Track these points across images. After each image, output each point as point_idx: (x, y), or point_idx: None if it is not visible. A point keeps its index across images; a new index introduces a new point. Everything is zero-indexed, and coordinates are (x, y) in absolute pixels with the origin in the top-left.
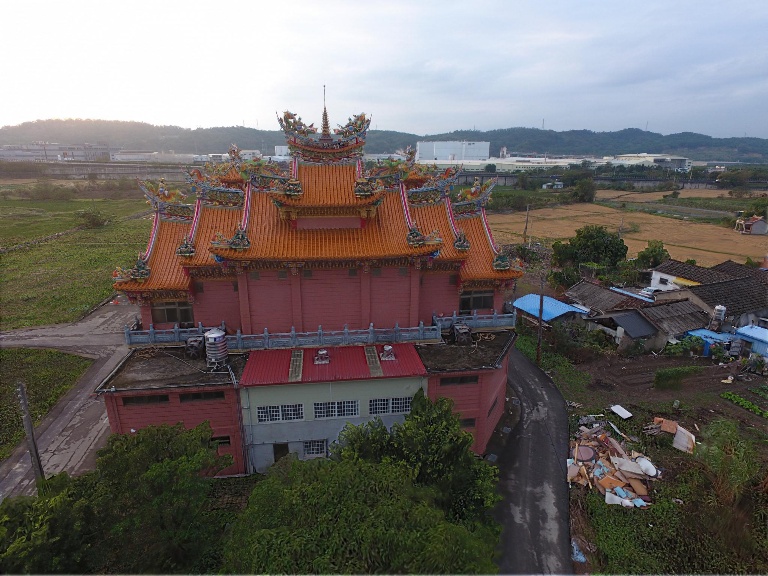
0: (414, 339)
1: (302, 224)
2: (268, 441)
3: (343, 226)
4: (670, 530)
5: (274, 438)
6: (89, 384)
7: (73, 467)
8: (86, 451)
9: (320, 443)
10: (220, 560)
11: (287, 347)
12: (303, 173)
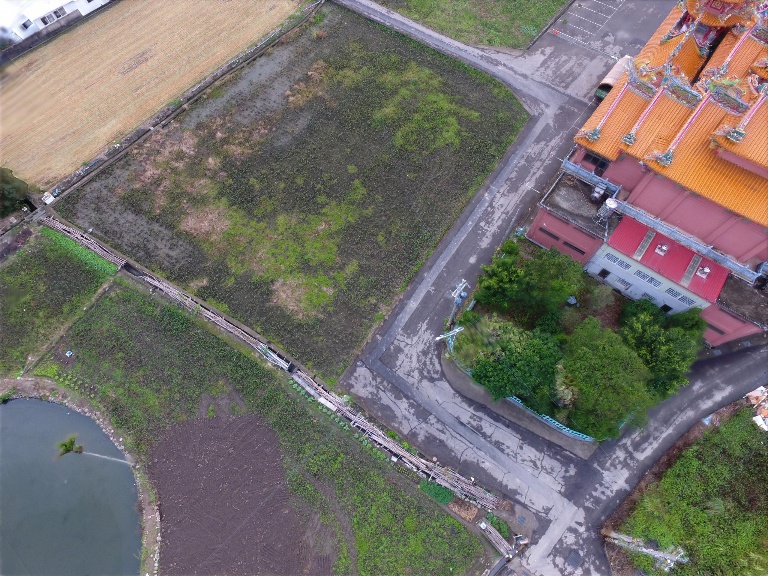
0: (733, 269)
1: (723, 154)
2: (602, 266)
3: (755, 171)
4: (767, 452)
5: (606, 267)
6: (524, 143)
7: (509, 212)
8: (515, 204)
9: (627, 283)
10: (559, 320)
11: (648, 225)
12: (761, 111)
